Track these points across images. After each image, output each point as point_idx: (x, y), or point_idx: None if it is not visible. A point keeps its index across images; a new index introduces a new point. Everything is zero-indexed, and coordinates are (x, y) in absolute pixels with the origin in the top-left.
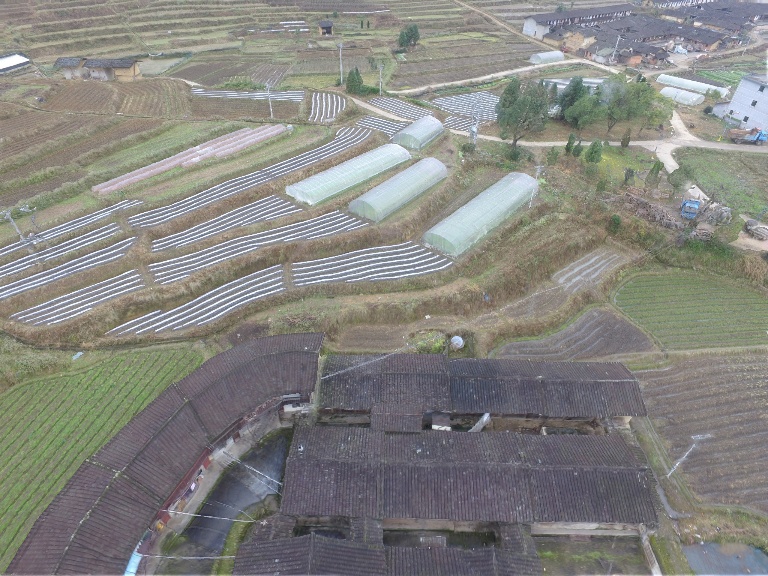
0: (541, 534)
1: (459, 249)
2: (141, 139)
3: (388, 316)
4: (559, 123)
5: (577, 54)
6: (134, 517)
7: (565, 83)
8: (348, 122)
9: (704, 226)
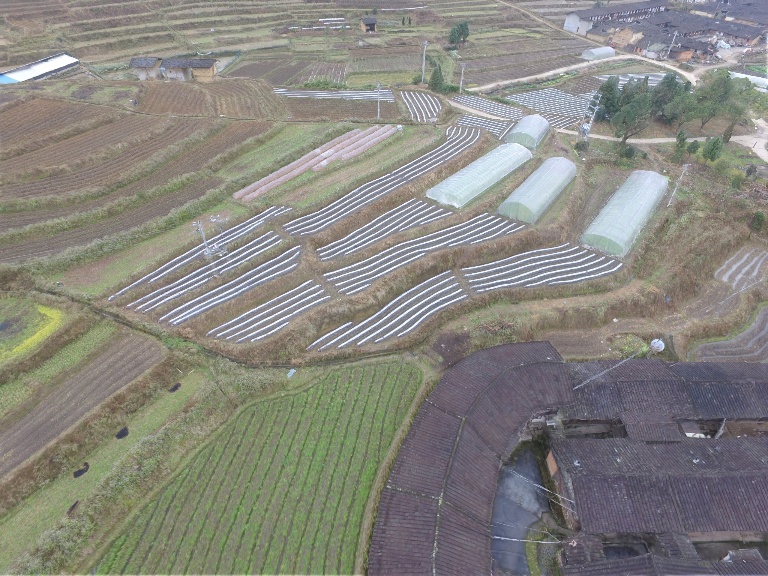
0: None
1: (625, 250)
2: (258, 142)
3: (579, 321)
4: (649, 119)
5: (625, 50)
6: (475, 546)
7: (626, 79)
8: (450, 121)
9: None
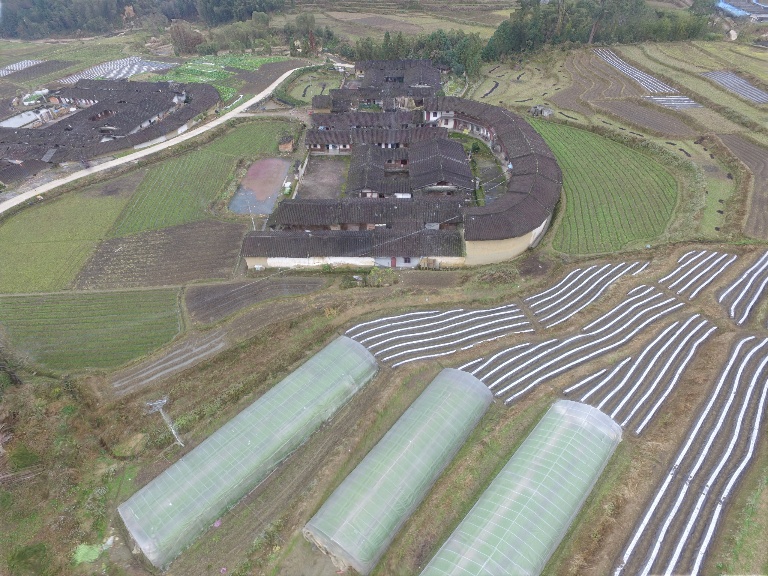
0: None
1: None
2: None
3: None
4: None
5: None
6: None
7: None
8: None
9: None
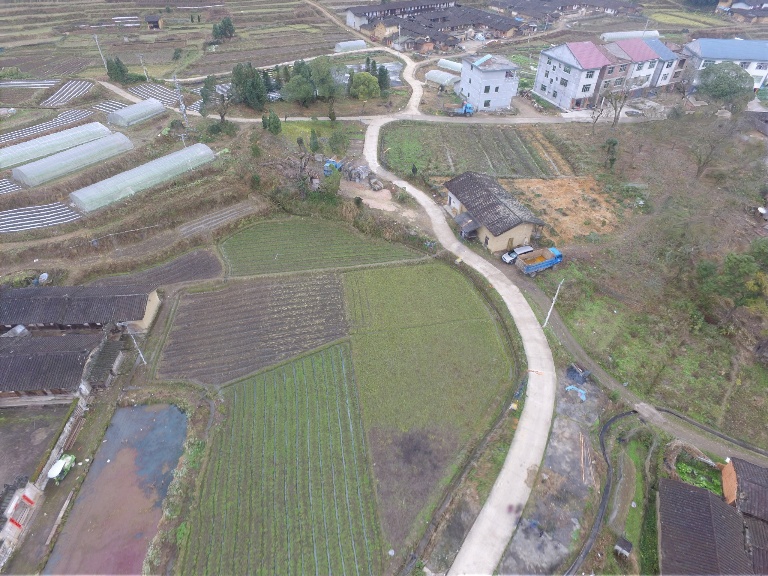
0: (5, 406)
1: (91, 206)
2: None
3: None
4: (295, 102)
5: (382, 43)
6: None
7: None
8: (82, 106)
9: (340, 182)
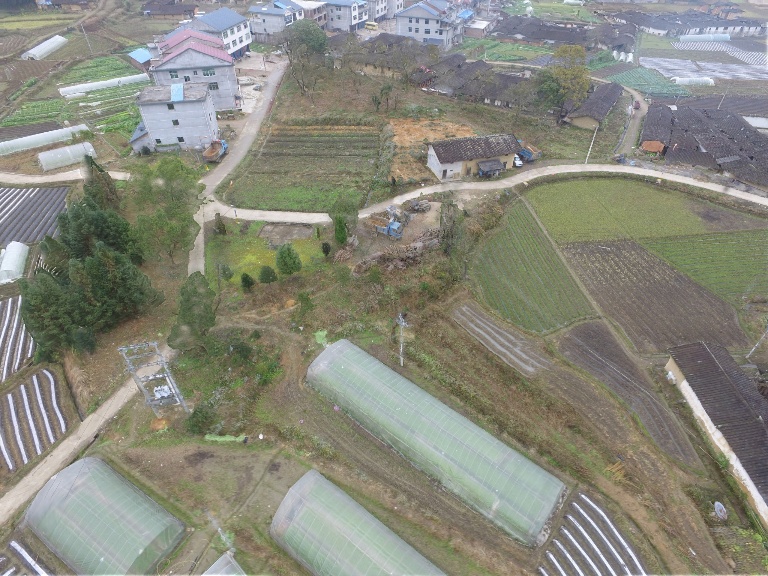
0: None
1: None
2: None
3: None
4: None
5: None
6: None
7: None
8: None
9: (408, 232)
